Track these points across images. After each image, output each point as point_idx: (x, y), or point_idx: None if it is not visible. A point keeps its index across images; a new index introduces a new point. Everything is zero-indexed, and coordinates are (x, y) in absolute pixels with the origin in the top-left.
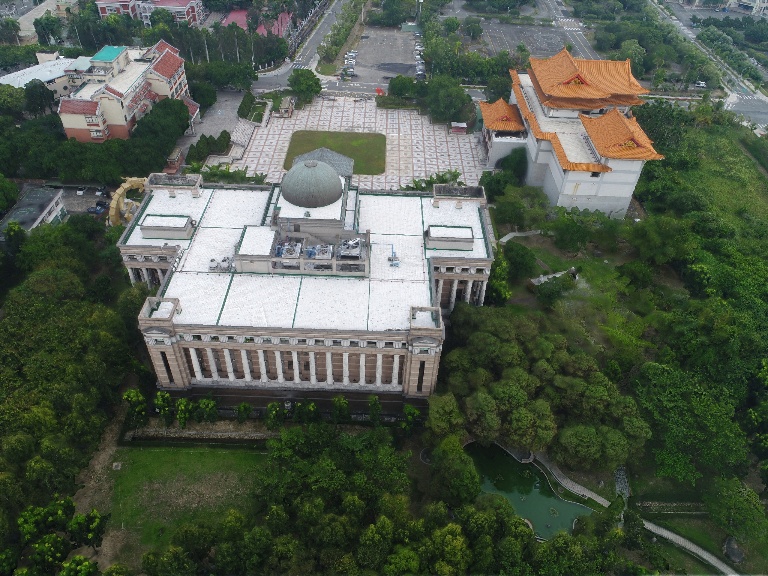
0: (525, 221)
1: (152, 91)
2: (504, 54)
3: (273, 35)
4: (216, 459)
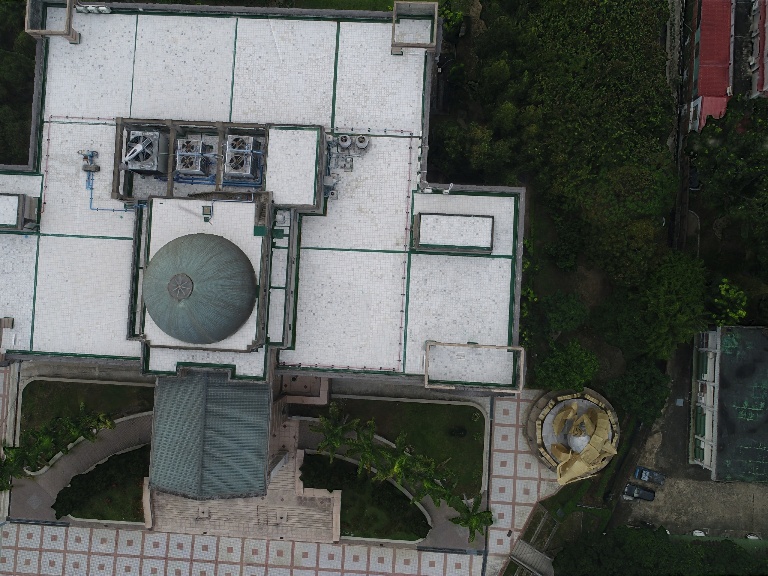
0: None
1: None
2: None
3: None
4: (358, 2)
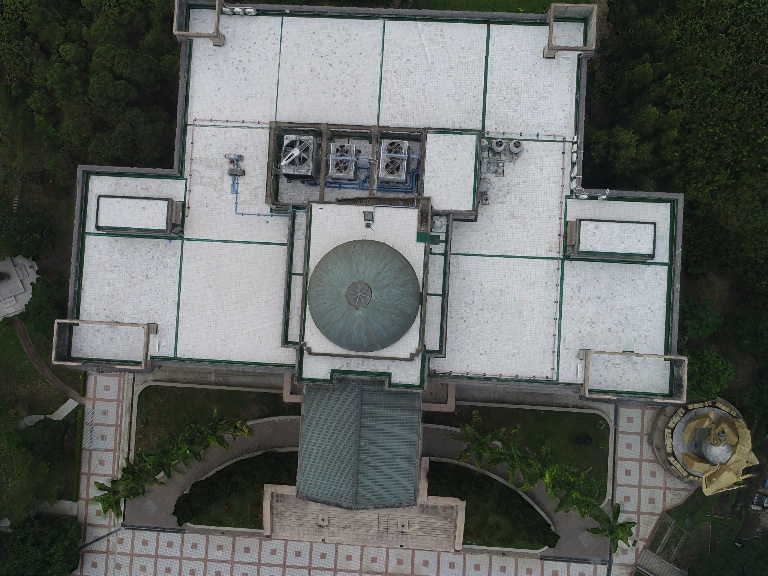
0: (19, 425)
1: None
2: None
3: None
4: (476, 4)
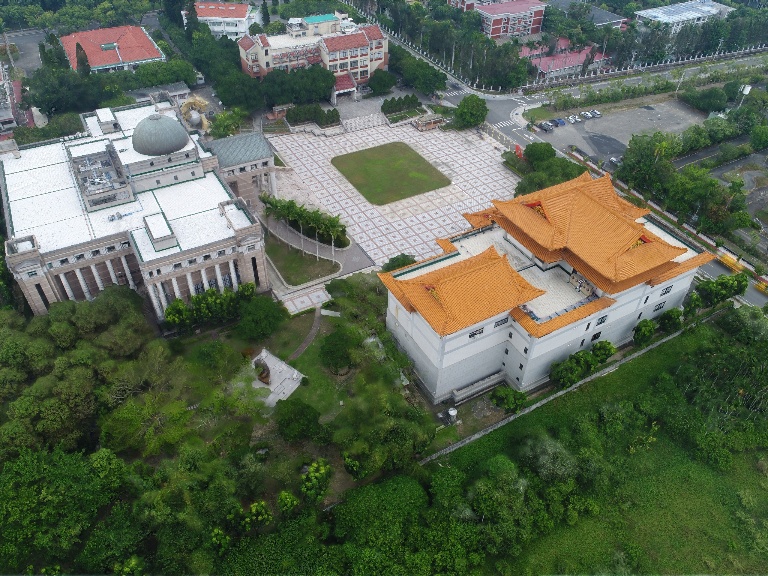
0: None
1: (321, 57)
2: (711, 183)
3: (508, 60)
4: None
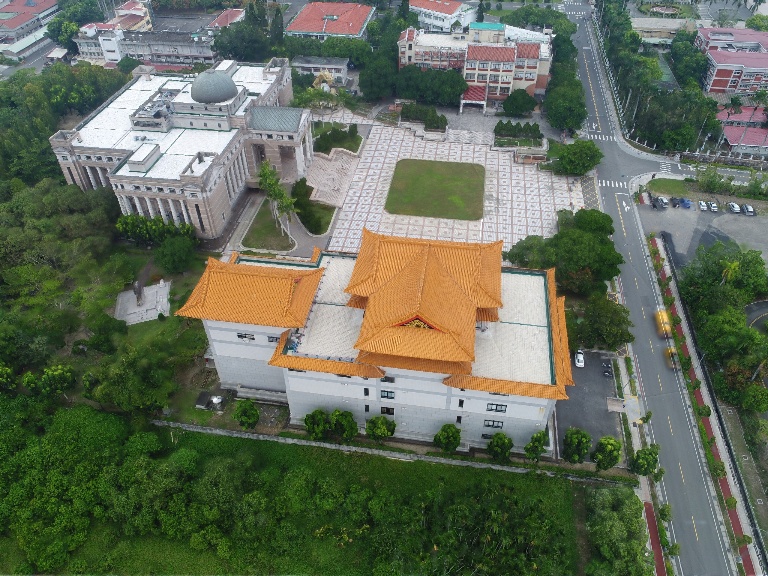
0: None
1: None
2: (751, 336)
3: (669, 116)
4: None
